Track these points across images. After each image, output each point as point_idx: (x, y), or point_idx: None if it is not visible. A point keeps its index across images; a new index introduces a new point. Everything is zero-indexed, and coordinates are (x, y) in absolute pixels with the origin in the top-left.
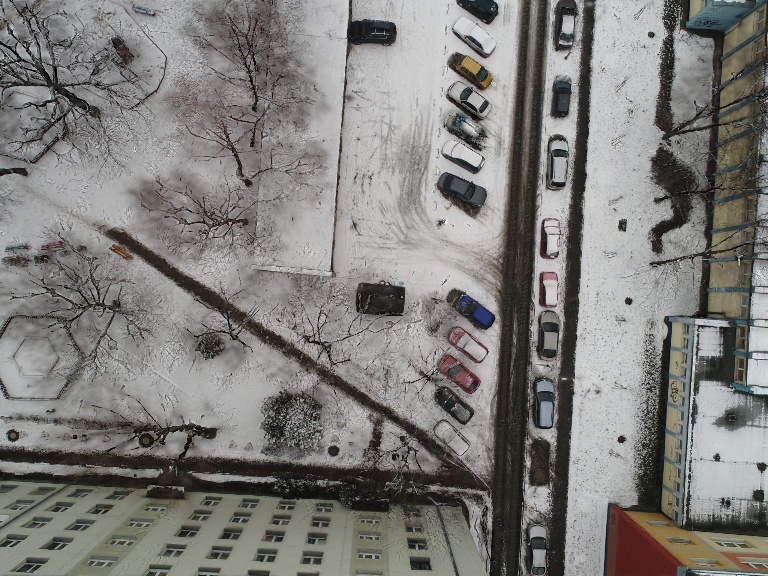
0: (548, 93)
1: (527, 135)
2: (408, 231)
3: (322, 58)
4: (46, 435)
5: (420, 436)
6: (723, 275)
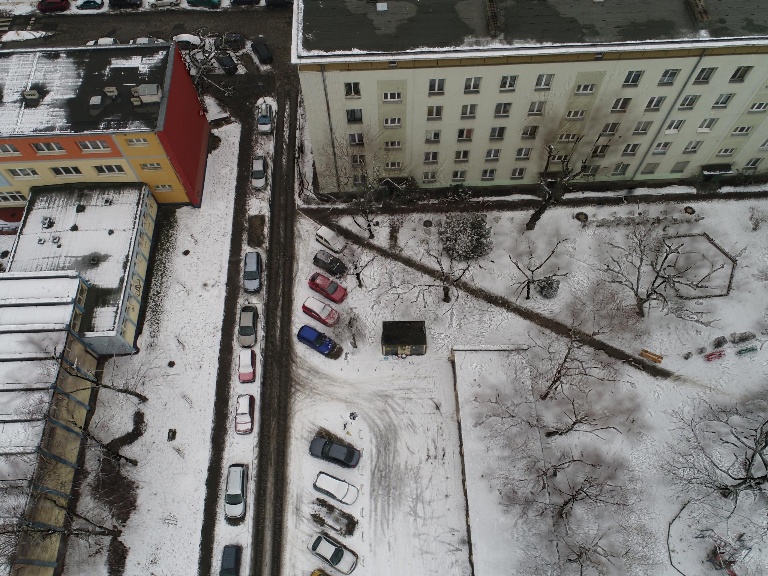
0: (245, 575)
1: (268, 522)
2: (385, 408)
3: (501, 571)
4: (663, 213)
5: (357, 240)
6: (80, 387)
